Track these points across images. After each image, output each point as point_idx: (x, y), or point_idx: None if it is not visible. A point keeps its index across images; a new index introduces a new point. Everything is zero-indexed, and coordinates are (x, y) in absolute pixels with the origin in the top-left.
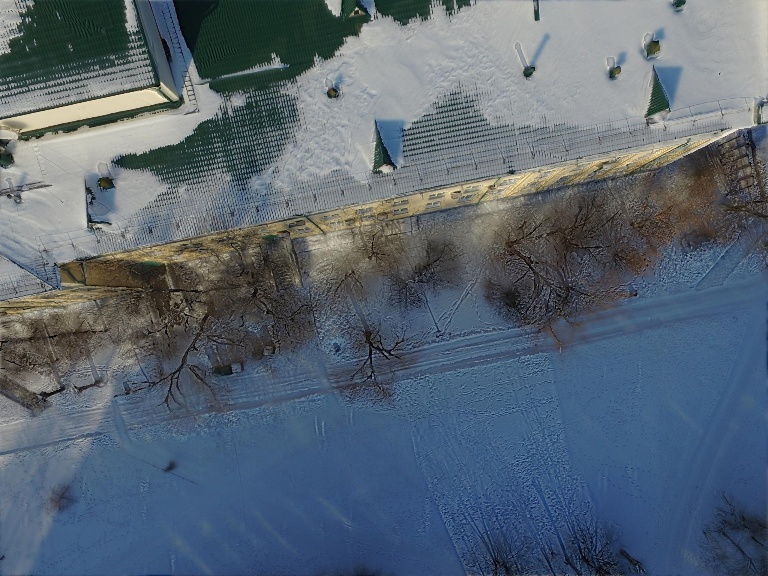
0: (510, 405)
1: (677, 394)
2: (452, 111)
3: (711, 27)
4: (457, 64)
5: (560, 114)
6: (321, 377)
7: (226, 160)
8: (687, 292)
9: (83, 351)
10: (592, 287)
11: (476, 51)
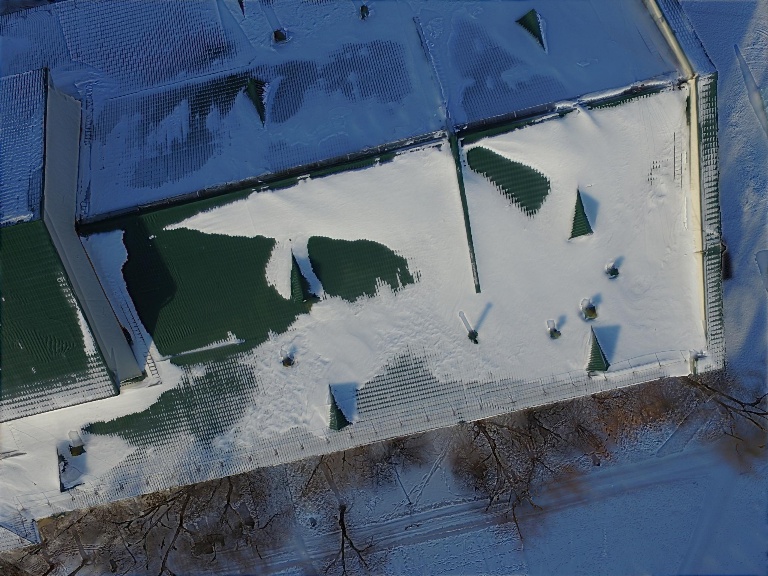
0: (481, 573)
1: (641, 558)
2: (402, 372)
3: (645, 289)
4: (405, 332)
5: (505, 370)
6: (299, 550)
7: (190, 423)
8: (648, 459)
9: (70, 531)
10: (556, 457)
11: (422, 320)
